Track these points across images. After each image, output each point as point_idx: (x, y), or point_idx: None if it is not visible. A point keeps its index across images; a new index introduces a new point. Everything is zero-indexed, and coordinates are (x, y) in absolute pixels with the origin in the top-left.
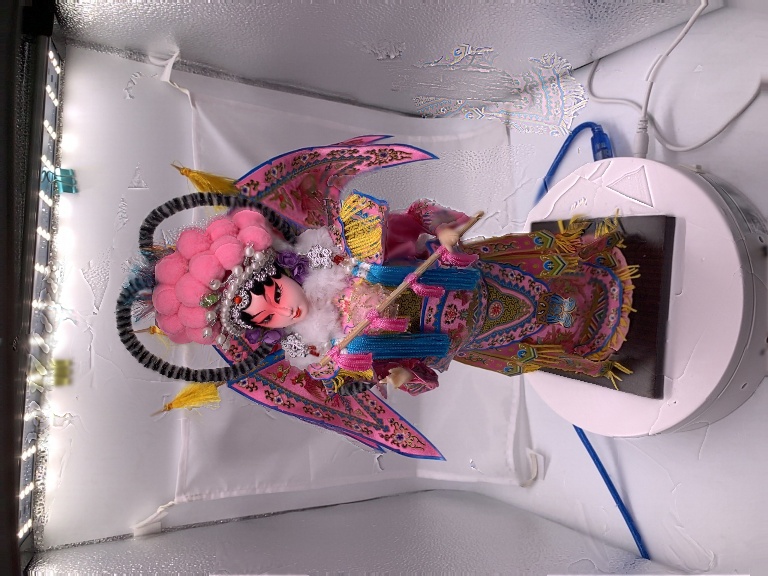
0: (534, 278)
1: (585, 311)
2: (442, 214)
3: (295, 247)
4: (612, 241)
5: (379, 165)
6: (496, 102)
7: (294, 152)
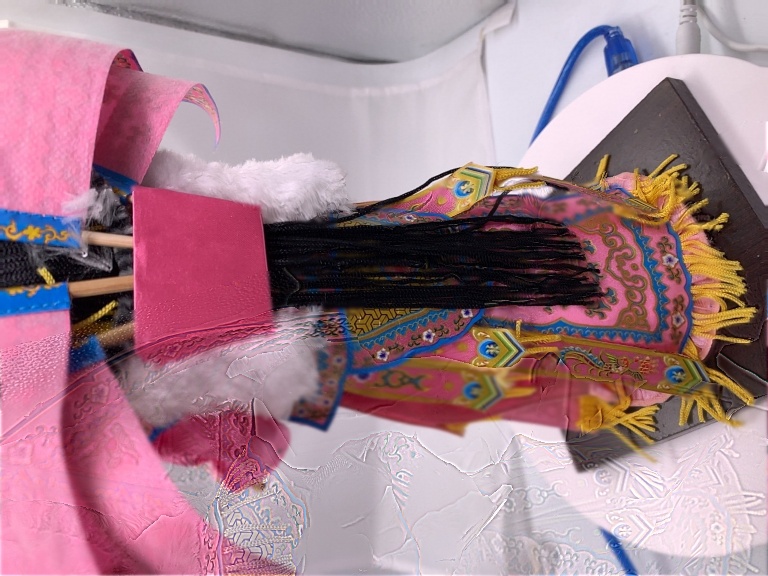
0: (595, 554)
1: (671, 569)
2: (428, 483)
3: (123, 570)
4: (716, 446)
5: (322, 337)
6: (548, 306)
7: (146, 346)
